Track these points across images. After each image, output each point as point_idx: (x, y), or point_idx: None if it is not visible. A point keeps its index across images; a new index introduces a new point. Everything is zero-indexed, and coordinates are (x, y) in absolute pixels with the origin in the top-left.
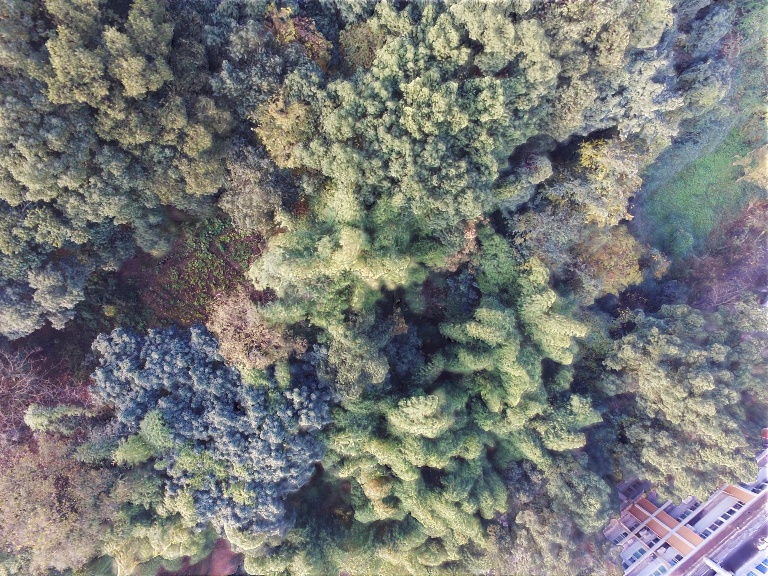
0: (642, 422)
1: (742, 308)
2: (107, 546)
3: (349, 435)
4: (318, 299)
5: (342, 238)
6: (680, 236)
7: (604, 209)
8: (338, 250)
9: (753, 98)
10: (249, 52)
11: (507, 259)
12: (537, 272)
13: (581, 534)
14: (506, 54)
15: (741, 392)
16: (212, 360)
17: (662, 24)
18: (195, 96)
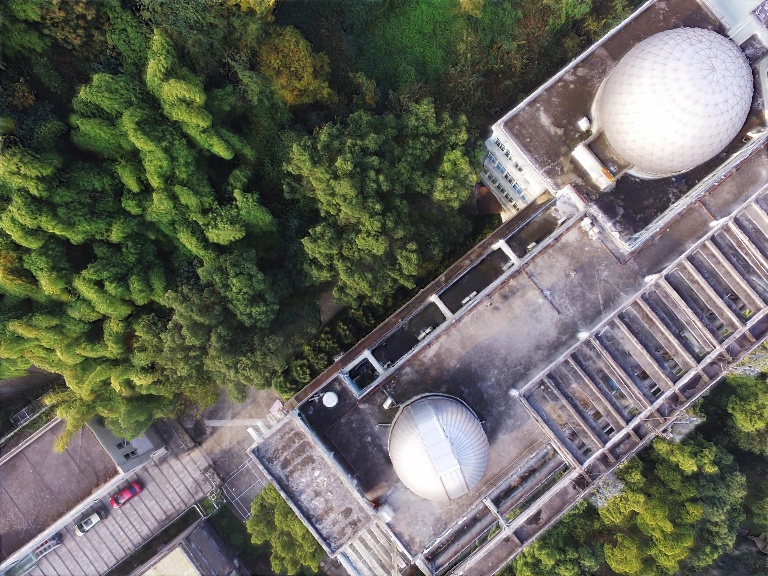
0: None
1: (416, 110)
2: None
3: None
4: None
5: None
6: (402, 69)
7: None
8: None
9: None
10: None
11: (137, 35)
12: (156, 41)
13: (250, 332)
14: None
15: (406, 187)
16: None
17: None
18: None
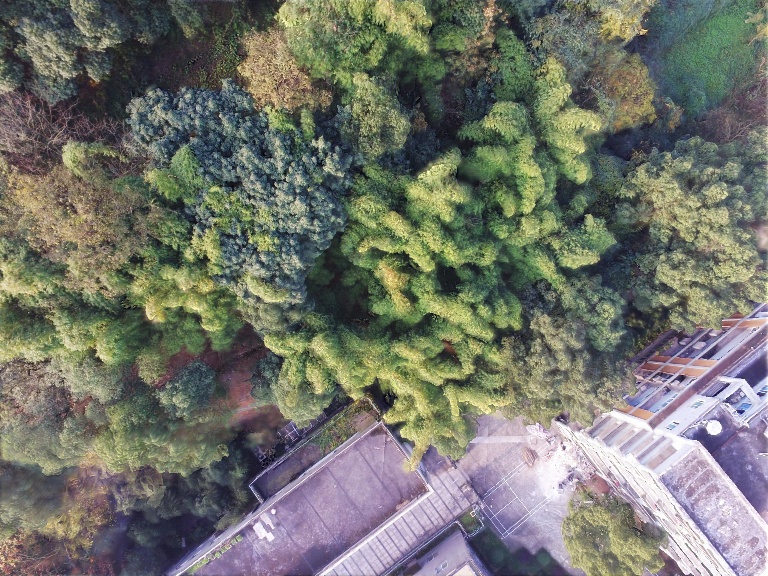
0: (656, 252)
1: (755, 138)
2: (136, 280)
3: (370, 197)
4: (344, 54)
5: None
6: (693, 94)
7: (619, 10)
8: None
9: None
10: None
11: (524, 63)
12: (553, 70)
13: (595, 355)
14: None
15: None
16: (241, 109)
17: None
18: None
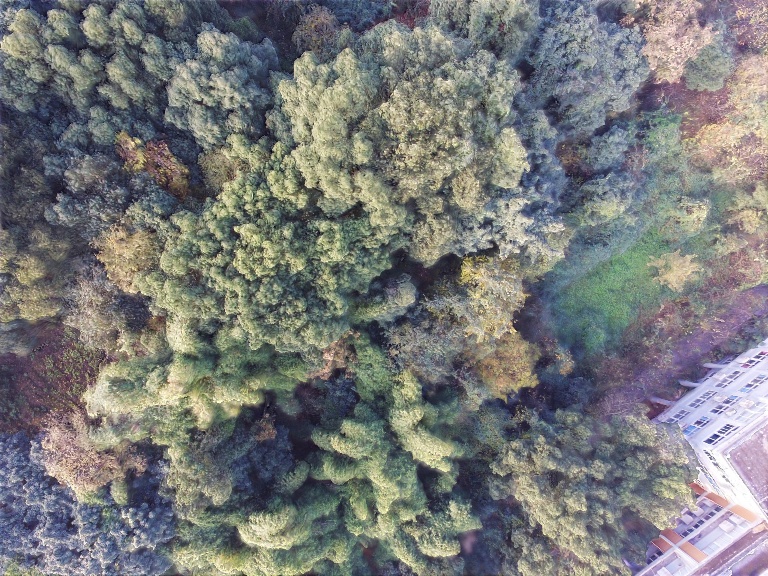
0: (525, 528)
1: (632, 422)
2: None
3: (191, 551)
4: (161, 419)
5: (169, 374)
6: (591, 332)
7: (479, 328)
8: (165, 386)
9: (667, 203)
10: (87, 184)
11: (382, 369)
12: (408, 387)
13: None
14: (348, 199)
15: (622, 509)
16: None
17: (520, 169)
18: (32, 223)
